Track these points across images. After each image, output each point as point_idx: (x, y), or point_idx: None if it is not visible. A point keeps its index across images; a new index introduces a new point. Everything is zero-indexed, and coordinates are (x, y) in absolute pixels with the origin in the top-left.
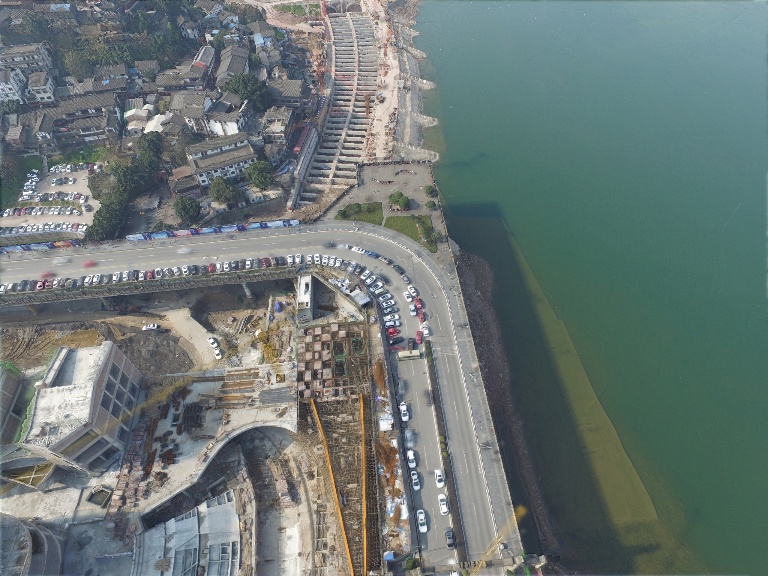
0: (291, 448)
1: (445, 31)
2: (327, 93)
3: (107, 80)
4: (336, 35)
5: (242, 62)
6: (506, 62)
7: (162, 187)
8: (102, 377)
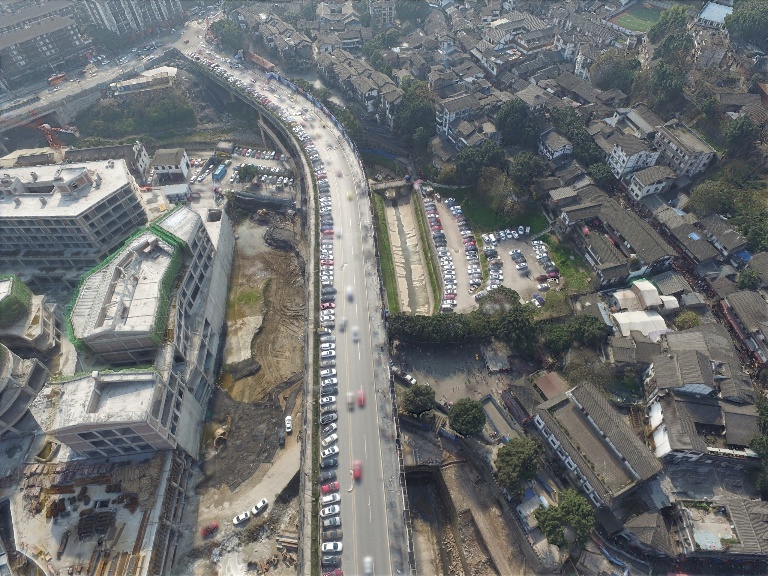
0: None
1: None
2: None
3: (699, 236)
4: None
5: None
6: None
7: (533, 365)
8: (99, 426)
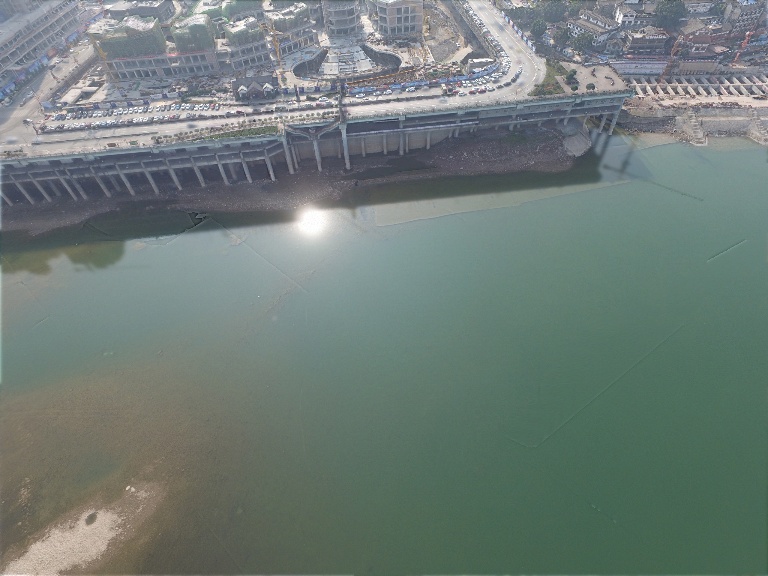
0: None
1: None
2: (738, 67)
3: None
4: None
5: (704, 0)
6: None
7: None
8: (407, 3)
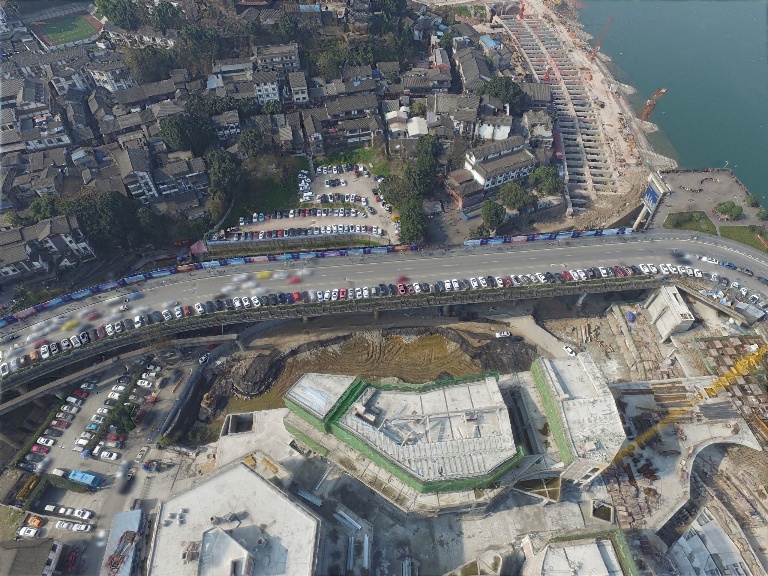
0: (725, 465)
1: (616, 34)
2: None
3: (358, 81)
4: (517, 37)
5: (484, 65)
6: (696, 67)
7: (435, 190)
8: None
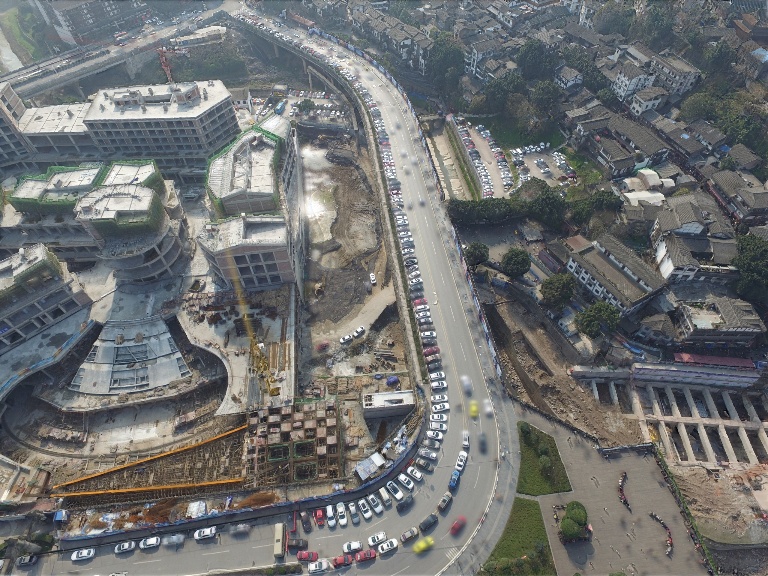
0: None
1: None
2: None
3: (689, 136)
4: None
5: None
6: None
7: (561, 236)
8: (252, 249)
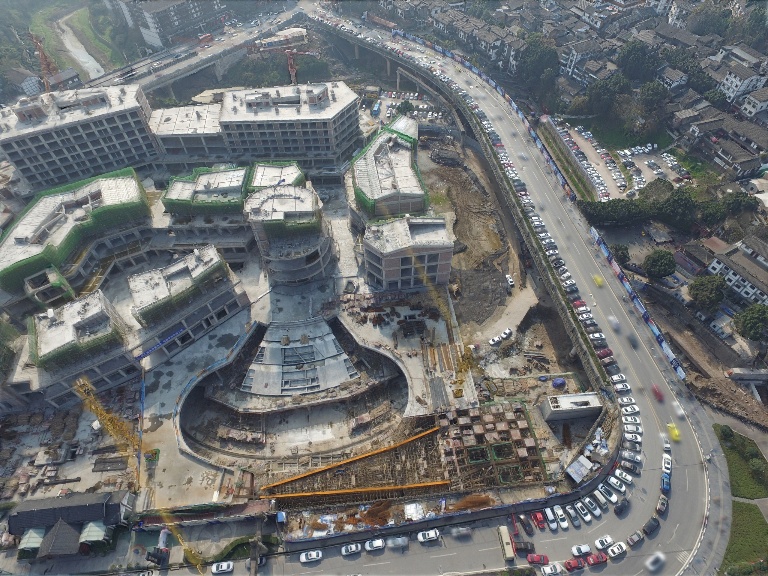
0: None
1: None
2: None
3: None
4: None
5: None
6: None
7: (690, 238)
8: (421, 250)
